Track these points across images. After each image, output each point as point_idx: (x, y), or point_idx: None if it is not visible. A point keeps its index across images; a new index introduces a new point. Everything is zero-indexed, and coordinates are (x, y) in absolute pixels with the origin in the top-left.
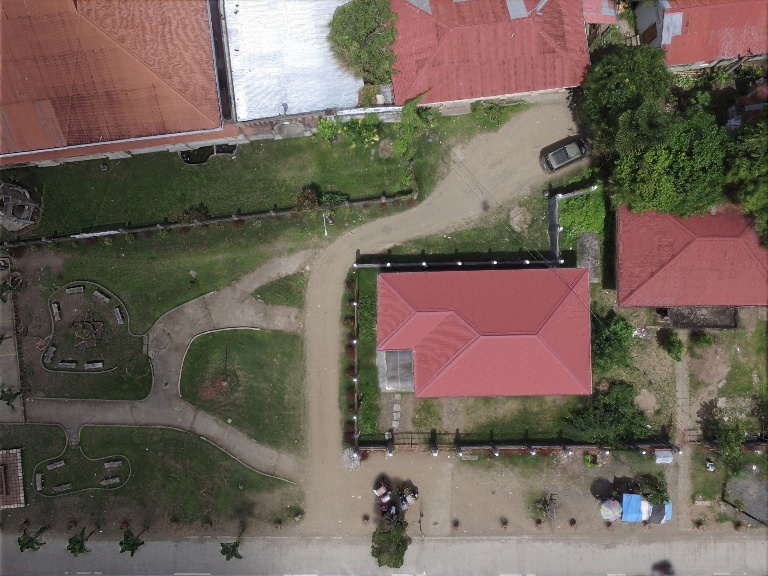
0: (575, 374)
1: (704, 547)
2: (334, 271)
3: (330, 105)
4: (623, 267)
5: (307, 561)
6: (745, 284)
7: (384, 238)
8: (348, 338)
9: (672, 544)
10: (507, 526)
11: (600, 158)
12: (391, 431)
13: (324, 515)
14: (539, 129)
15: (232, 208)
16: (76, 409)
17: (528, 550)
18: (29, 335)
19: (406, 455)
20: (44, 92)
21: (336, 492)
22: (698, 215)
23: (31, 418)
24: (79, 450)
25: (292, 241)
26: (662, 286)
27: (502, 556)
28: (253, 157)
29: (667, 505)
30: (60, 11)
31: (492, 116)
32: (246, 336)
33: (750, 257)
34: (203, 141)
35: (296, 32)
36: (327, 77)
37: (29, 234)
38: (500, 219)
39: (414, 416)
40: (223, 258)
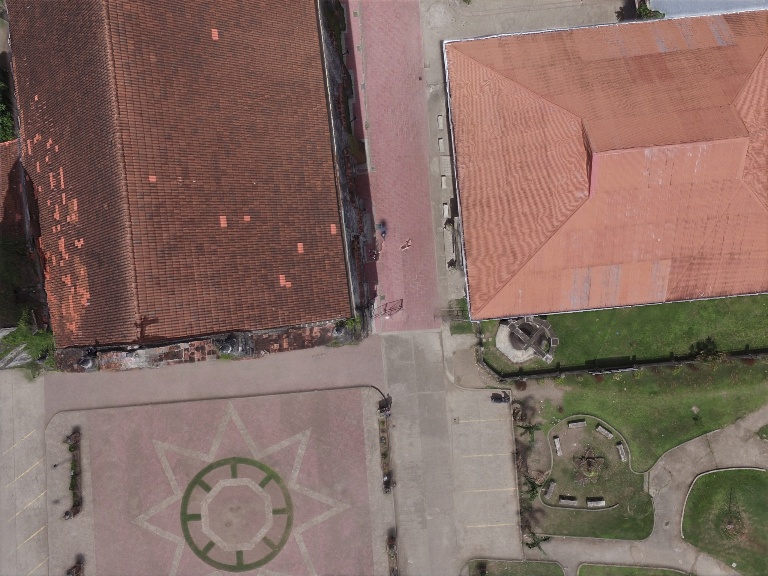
0: None
1: None
2: None
3: None
4: None
5: None
6: None
7: None
8: None
9: None
10: None
11: None
12: None
13: None
14: None
15: (740, 344)
16: (574, 547)
17: None
18: (529, 469)
19: None
20: (669, 252)
21: None
22: None
23: (528, 555)
24: None
25: None
26: None
27: None
28: None
29: None
30: (725, 178)
31: None
32: (751, 477)
33: None
34: None
35: None
36: None
37: (531, 365)
38: None
39: None
40: (727, 395)
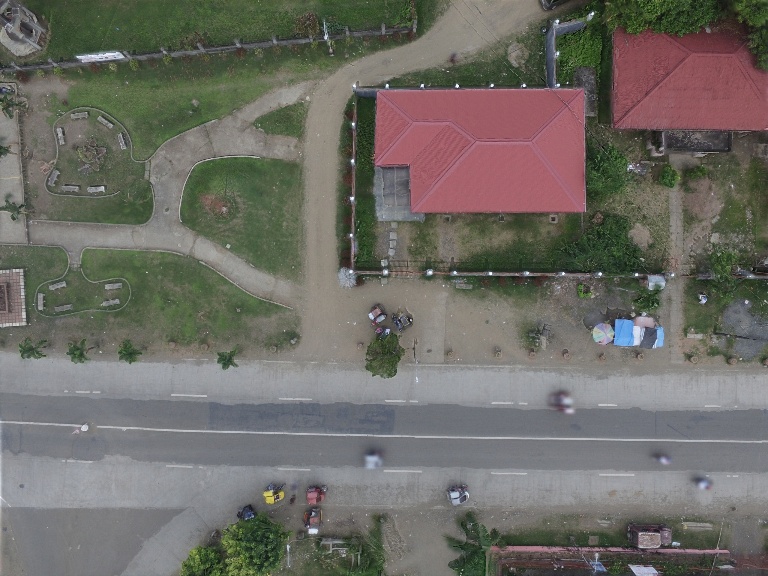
0: (569, 189)
1: (695, 380)
2: (334, 102)
3: None
4: (618, 92)
5: (302, 385)
6: (739, 105)
7: (383, 71)
8: (346, 165)
9: (664, 376)
10: (500, 353)
11: None
12: (387, 259)
13: (320, 340)
14: None
15: (235, 38)
16: (78, 232)
17: (520, 379)
18: (34, 159)
19: (401, 283)
20: None
21: (332, 318)
22: (693, 32)
23: (34, 240)
24: (80, 272)
25: (293, 72)
26: (657, 106)
27: (495, 384)
28: None
29: (659, 331)
30: None
31: None
32: (246, 164)
33: (744, 77)
34: None
35: None
36: None
37: (36, 60)
38: (498, 54)
39: (410, 245)
40: (225, 88)
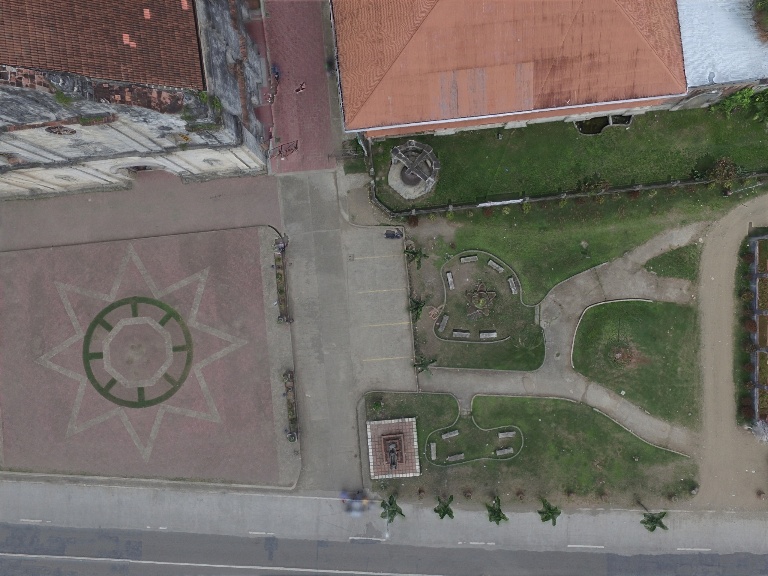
0: None
1: None
2: (727, 244)
3: (753, 75)
4: None
5: (700, 535)
6: None
7: None
8: (746, 311)
9: None
10: None
11: None
12: None
13: (718, 489)
14: None
15: (626, 179)
16: (468, 379)
17: None
18: None
19: None
20: (531, 54)
21: (730, 466)
22: None
23: (423, 387)
24: (471, 420)
25: (684, 213)
26: None
27: None
28: (646, 128)
29: None
30: None
31: None
32: (639, 308)
33: None
34: (605, 111)
35: (722, 1)
36: (749, 47)
37: (423, 203)
38: None
39: None
40: (615, 229)
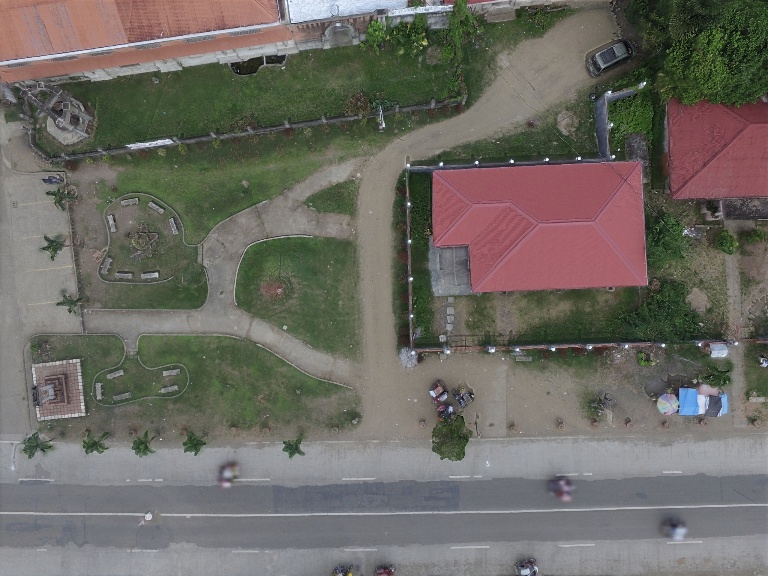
0: (631, 264)
1: (759, 443)
2: (385, 178)
3: (380, 7)
4: (674, 161)
5: (365, 464)
6: None
7: (433, 144)
8: (401, 242)
9: (727, 441)
10: (563, 425)
11: (646, 60)
12: (445, 334)
13: (381, 419)
14: (584, 34)
15: (283, 118)
16: (133, 319)
17: (584, 450)
18: (86, 247)
19: (460, 358)
20: None
21: (392, 396)
22: (750, 102)
23: (89, 329)
24: (137, 360)
25: (342, 149)
26: (715, 176)
27: (558, 456)
28: (302, 67)
29: (723, 399)
30: None
31: (538, 20)
32: (299, 244)
33: None
34: (254, 50)
35: None
36: None
37: (84, 148)
38: (548, 123)
39: (468, 319)
40: (275, 168)
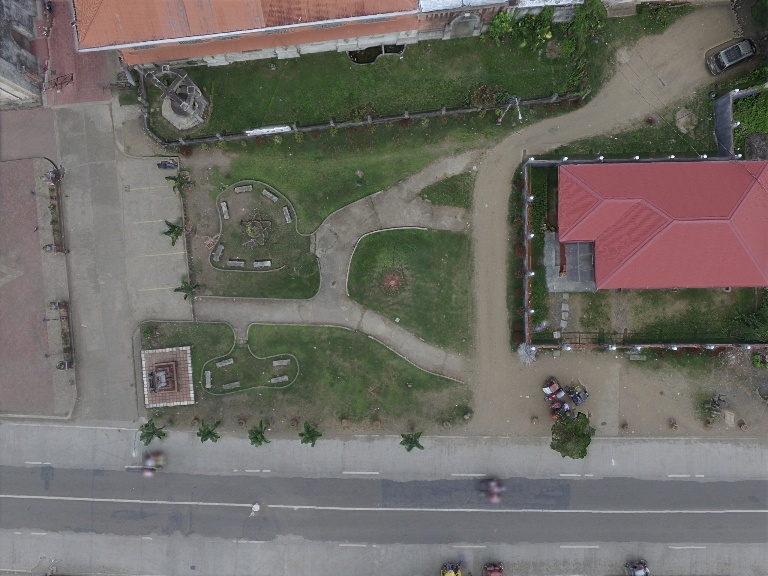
0: (760, 264)
1: None
2: (501, 171)
3: None
4: None
5: (475, 460)
6: None
7: (550, 139)
8: (517, 237)
9: None
10: (677, 425)
11: (767, 59)
12: (559, 331)
13: (492, 414)
14: (704, 31)
15: (400, 108)
16: (244, 308)
17: (696, 451)
18: (198, 234)
19: (574, 355)
20: None
21: (504, 391)
22: None
23: (199, 317)
24: (247, 349)
25: (459, 141)
26: None
27: (670, 457)
28: (420, 57)
29: None
30: None
31: (660, 16)
32: (413, 236)
33: None
34: (374, 39)
35: None
36: None
37: (198, 133)
38: (666, 120)
39: (582, 316)
40: (390, 158)
